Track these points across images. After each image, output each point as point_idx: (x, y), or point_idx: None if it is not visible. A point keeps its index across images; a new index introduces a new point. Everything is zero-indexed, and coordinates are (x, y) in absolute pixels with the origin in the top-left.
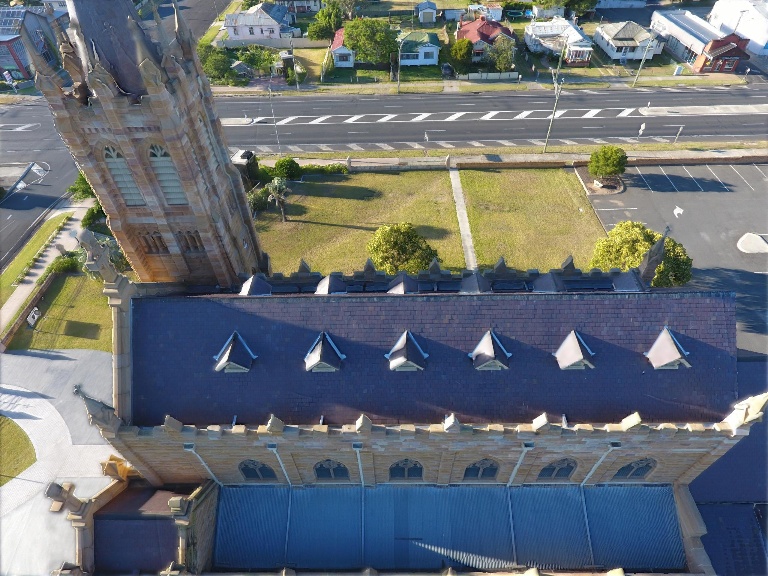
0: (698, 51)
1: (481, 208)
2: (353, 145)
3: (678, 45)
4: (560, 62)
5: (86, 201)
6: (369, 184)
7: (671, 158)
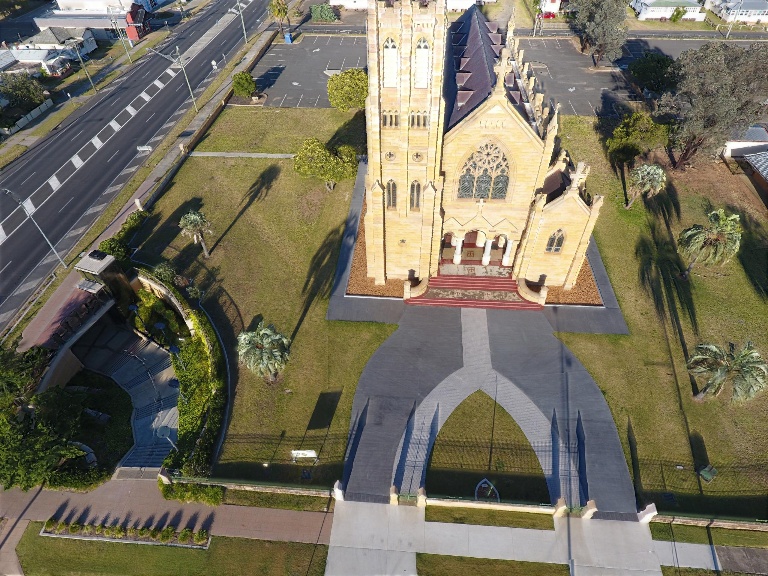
0: (123, 25)
1: (254, 146)
2: (91, 210)
3: (95, 32)
4: (84, 67)
5: (5, 511)
6: (179, 200)
7: (245, 70)
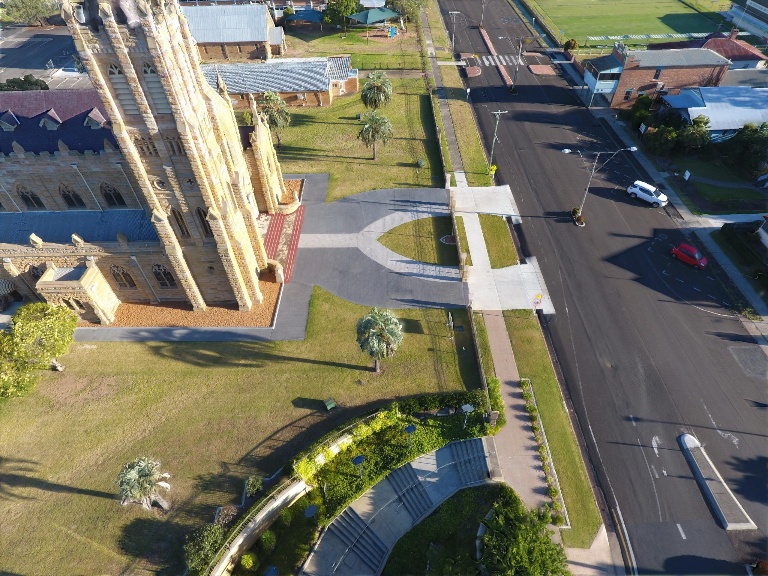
0: None
1: None
2: None
3: None
4: None
5: None
6: None
7: None
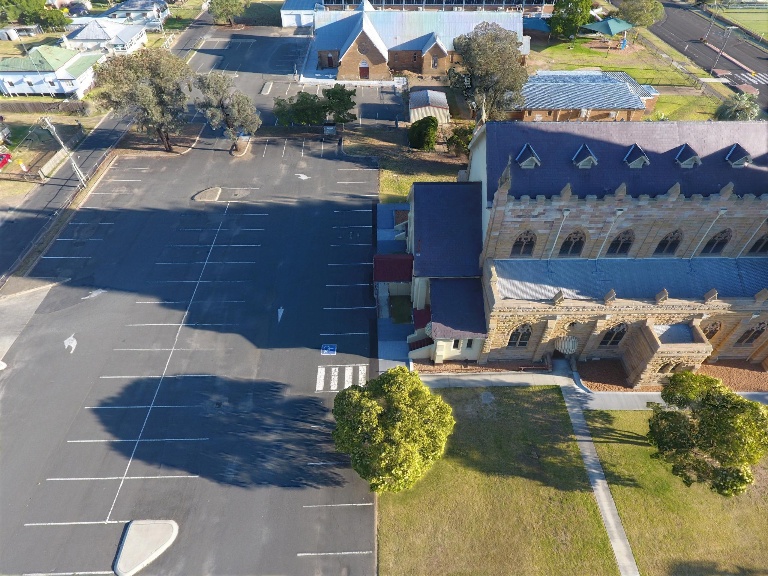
0: None
1: None
2: None
3: None
4: None
5: None
6: None
7: None
